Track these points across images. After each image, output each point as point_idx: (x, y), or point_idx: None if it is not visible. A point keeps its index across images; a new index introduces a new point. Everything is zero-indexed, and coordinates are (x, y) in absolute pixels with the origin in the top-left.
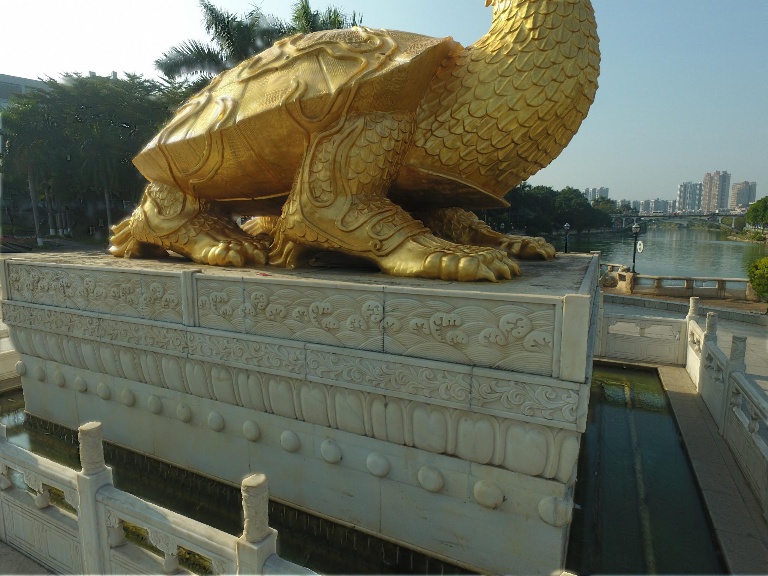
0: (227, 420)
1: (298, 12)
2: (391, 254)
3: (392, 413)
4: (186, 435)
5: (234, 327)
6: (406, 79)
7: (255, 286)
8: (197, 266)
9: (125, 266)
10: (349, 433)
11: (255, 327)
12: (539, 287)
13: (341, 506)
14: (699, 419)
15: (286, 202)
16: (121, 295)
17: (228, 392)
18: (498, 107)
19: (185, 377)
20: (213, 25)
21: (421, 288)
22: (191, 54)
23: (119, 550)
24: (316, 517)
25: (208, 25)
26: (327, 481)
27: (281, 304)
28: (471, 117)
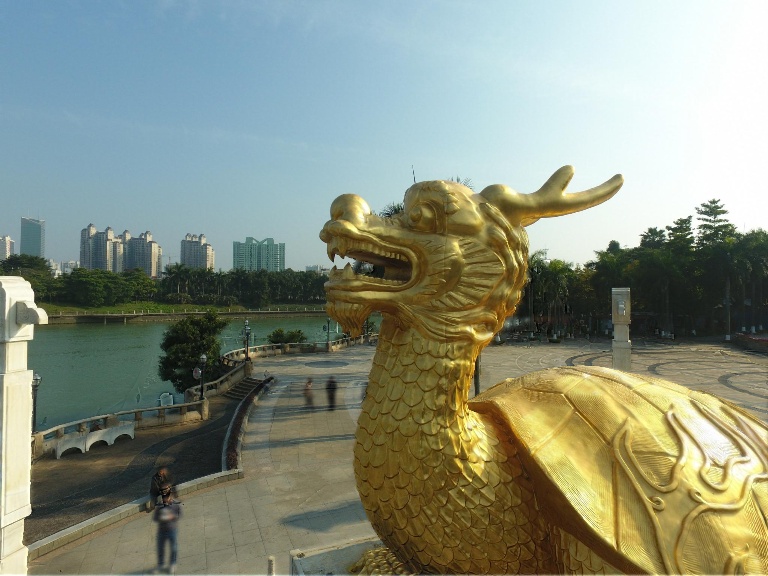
0: None
1: None
2: None
3: None
4: None
5: None
6: None
7: None
8: None
9: None
10: None
11: None
12: (325, 570)
13: None
14: None
15: None
16: None
17: None
18: None
19: None
20: None
21: (362, 538)
22: None
23: None
24: None
25: None
26: None
27: None
28: None
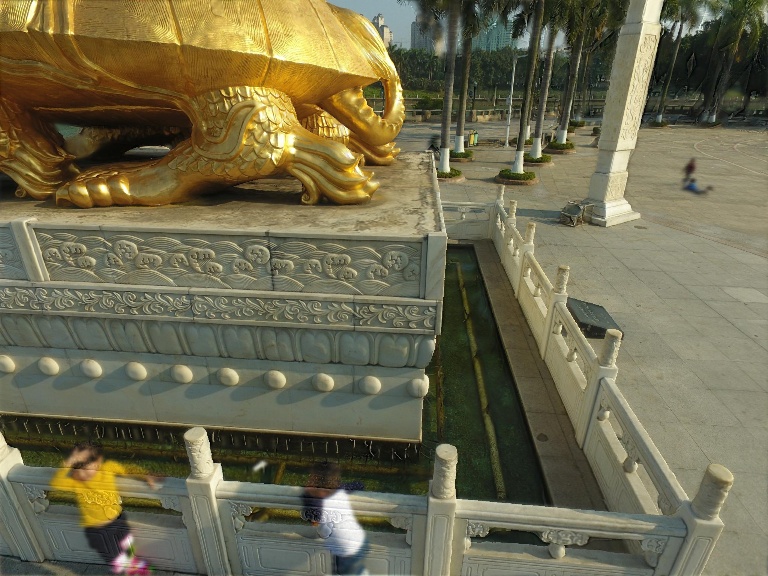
0: None
1: None
2: None
3: None
4: None
5: None
6: None
7: None
8: None
9: None
10: None
11: None
12: None
13: None
14: None
15: None
16: None
17: None
18: None
19: None
20: None
21: None
22: None
23: None
24: None
25: None
26: None
27: None
28: None
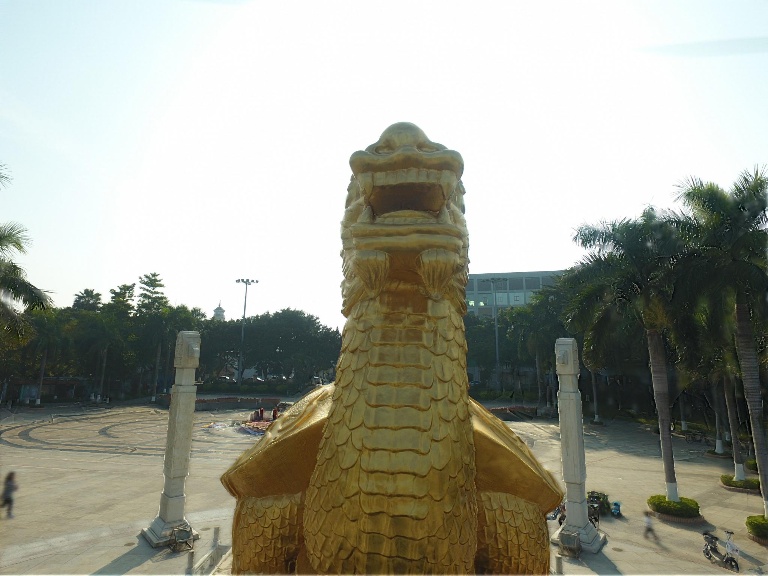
0: None
1: (684, 199)
2: None
3: None
4: None
5: None
6: (251, 476)
7: None
8: None
9: None
10: None
11: None
12: None
13: None
14: None
15: None
16: None
17: None
18: None
19: None
20: (591, 241)
21: None
22: (590, 264)
23: None
24: None
25: (585, 243)
26: None
27: None
28: None
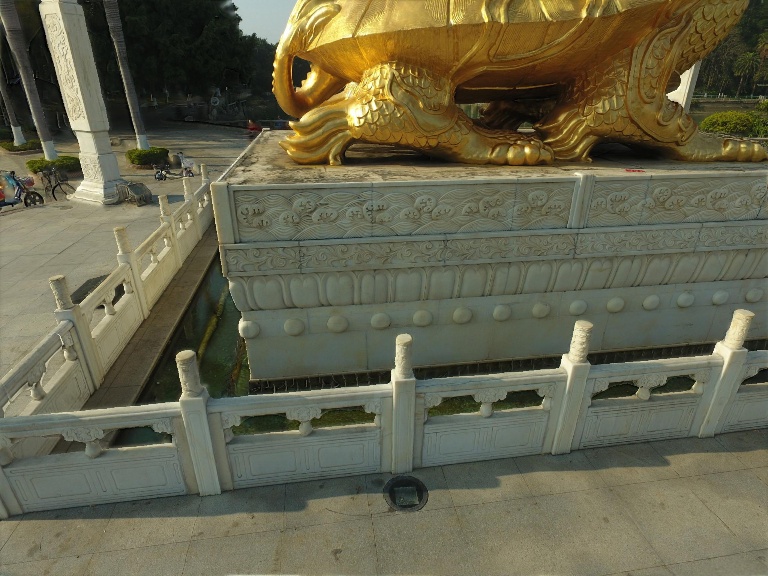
0: (591, 303)
1: None
2: (688, 143)
3: (750, 260)
4: (537, 329)
5: (628, 221)
6: None
7: (663, 182)
8: (513, 168)
9: (453, 176)
10: (704, 282)
11: (651, 218)
12: None
13: (681, 334)
14: None
15: (606, 97)
16: (482, 209)
17: (604, 279)
18: (722, 13)
19: (555, 277)
20: None
21: None
22: None
23: (743, 391)
24: (660, 349)
25: None
26: (675, 321)
27: (682, 195)
28: (704, 19)
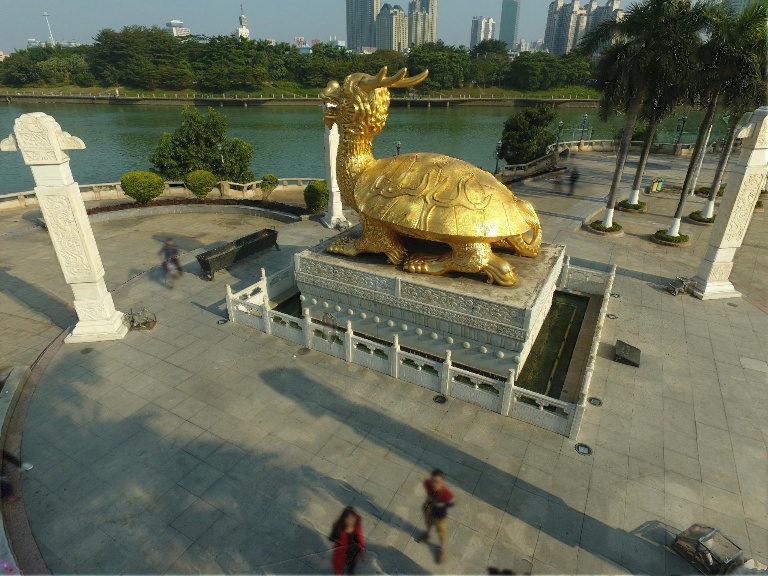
0: None
1: None
2: None
3: None
4: None
5: None
6: None
7: None
8: None
9: None
10: None
11: None
12: None
13: None
14: (292, 290)
15: None
16: None
17: None
18: None
19: None
20: None
21: None
22: None
23: None
24: None
25: None
26: None
27: None
28: None
